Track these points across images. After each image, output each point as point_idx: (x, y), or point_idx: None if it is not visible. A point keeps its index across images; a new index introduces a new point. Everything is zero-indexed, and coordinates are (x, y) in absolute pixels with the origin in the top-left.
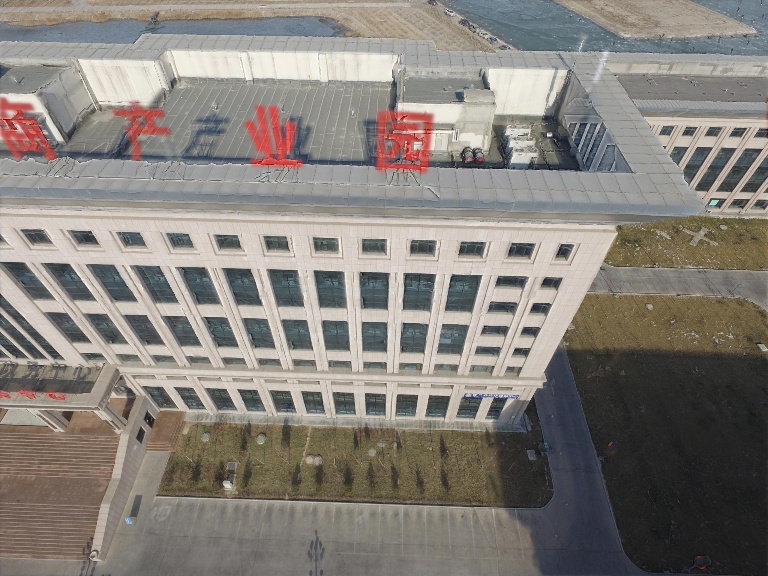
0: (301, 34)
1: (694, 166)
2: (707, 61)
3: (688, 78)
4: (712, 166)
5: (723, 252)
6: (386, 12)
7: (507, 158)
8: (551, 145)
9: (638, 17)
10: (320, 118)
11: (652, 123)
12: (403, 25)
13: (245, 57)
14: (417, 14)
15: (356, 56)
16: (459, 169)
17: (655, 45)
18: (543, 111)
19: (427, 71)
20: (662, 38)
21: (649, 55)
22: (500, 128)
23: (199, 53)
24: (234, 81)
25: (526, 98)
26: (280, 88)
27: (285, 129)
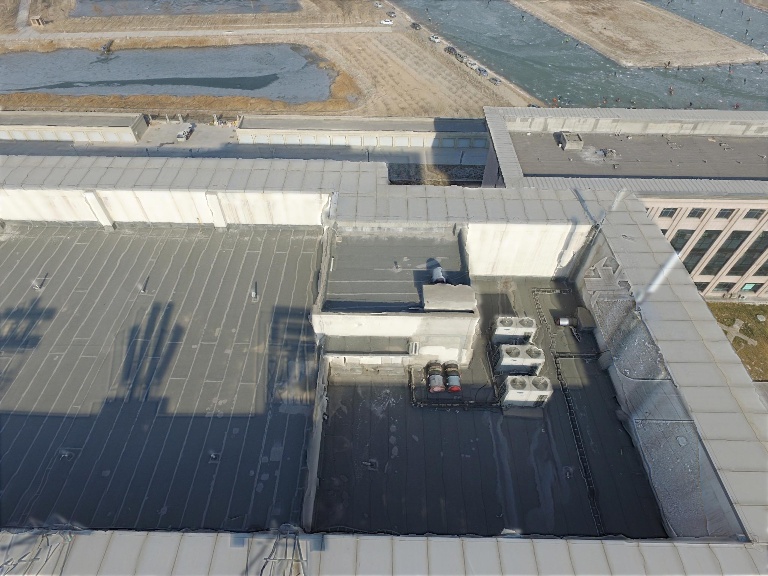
0: (270, 65)
1: (727, 250)
2: (739, 120)
3: (716, 139)
4: (749, 250)
5: (765, 355)
6: (365, 38)
7: (498, 386)
8: (567, 340)
9: (640, 42)
10: (200, 305)
11: (679, 205)
12: (383, 54)
13: (92, 198)
14: (399, 40)
15: (264, 195)
16: (401, 539)
17: (660, 75)
18: (552, 272)
19: (371, 226)
20: (667, 67)
21: (669, 112)
22: (487, 302)
23: (21, 192)
24: (86, 224)
25: (526, 257)
26: (153, 237)
27: (136, 335)
